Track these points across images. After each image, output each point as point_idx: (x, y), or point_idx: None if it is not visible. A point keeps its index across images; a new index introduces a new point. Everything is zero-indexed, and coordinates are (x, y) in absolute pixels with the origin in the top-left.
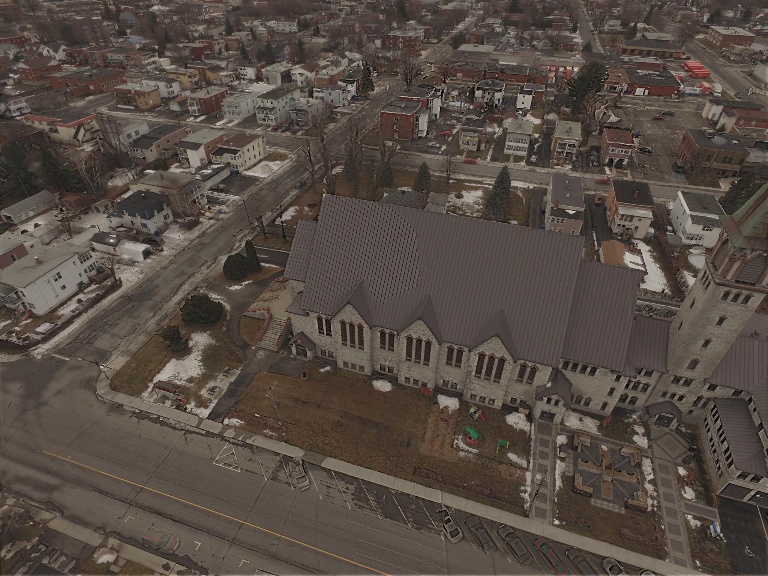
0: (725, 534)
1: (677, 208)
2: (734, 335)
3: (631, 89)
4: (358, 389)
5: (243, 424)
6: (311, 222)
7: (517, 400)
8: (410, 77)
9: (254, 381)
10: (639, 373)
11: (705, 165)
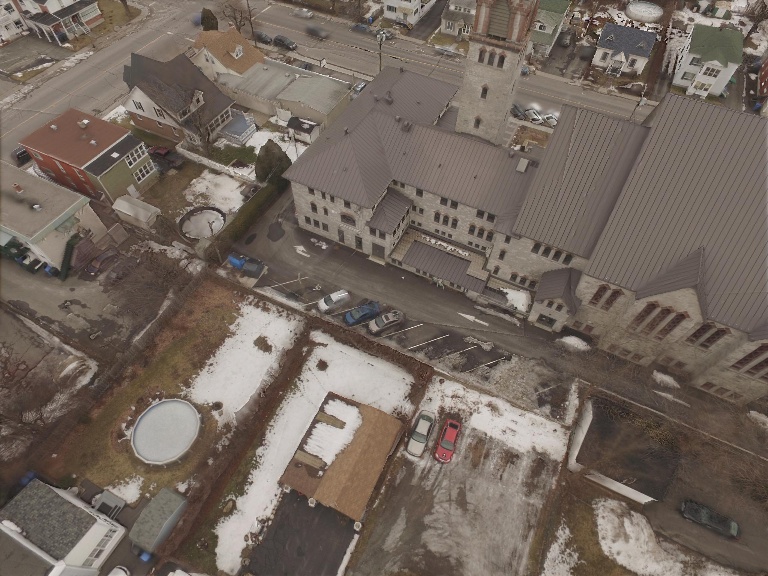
0: None
1: None
2: None
3: None
4: None
5: None
6: None
7: None
8: None
9: None
10: None
11: None
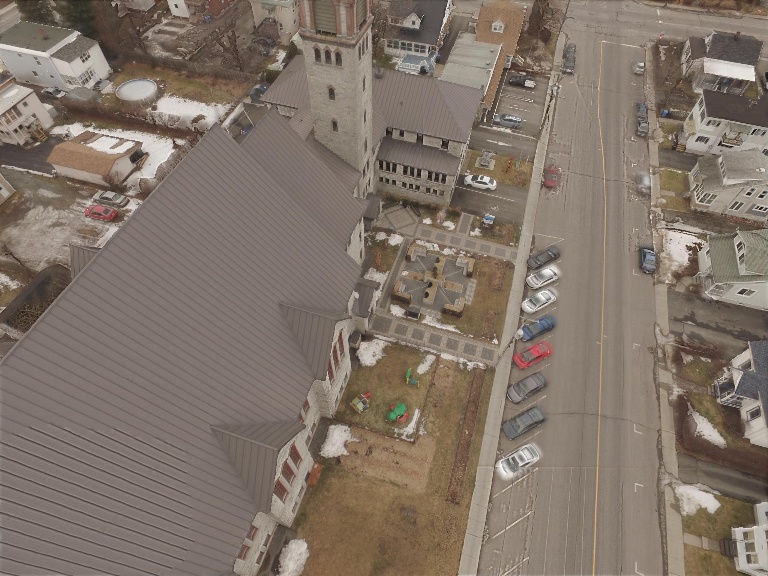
0: None
1: (17, 64)
2: None
3: None
4: None
5: None
6: None
7: None
8: None
9: None
10: None
11: None
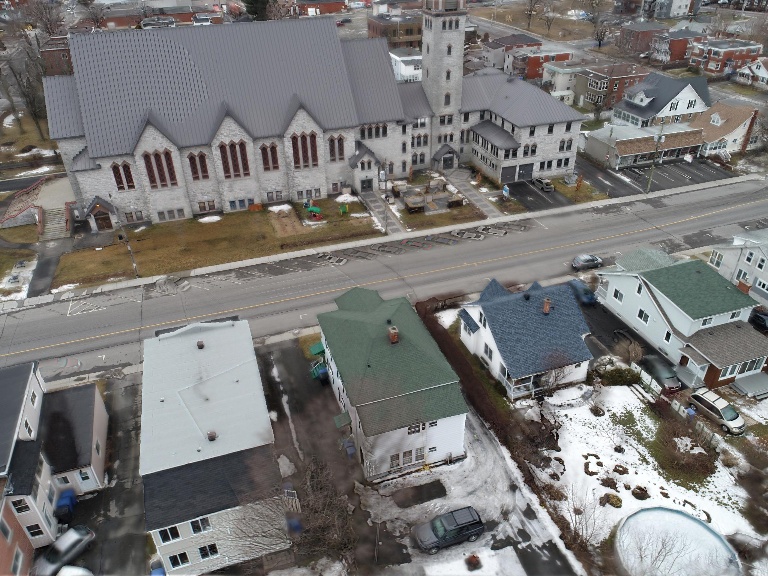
0: (514, 197)
1: None
2: (461, 60)
3: (303, 11)
4: (187, 228)
5: (78, 285)
6: (59, 76)
7: (338, 185)
8: (51, 26)
9: (62, 260)
10: (417, 126)
11: (395, 40)
